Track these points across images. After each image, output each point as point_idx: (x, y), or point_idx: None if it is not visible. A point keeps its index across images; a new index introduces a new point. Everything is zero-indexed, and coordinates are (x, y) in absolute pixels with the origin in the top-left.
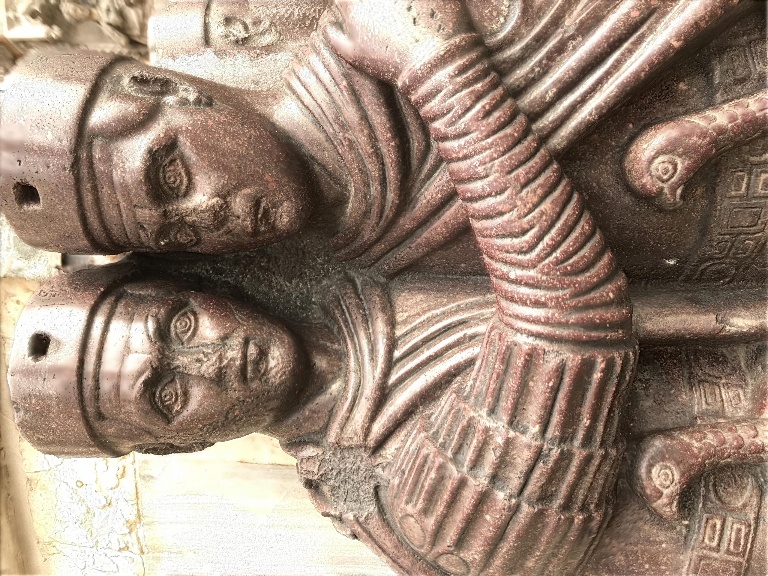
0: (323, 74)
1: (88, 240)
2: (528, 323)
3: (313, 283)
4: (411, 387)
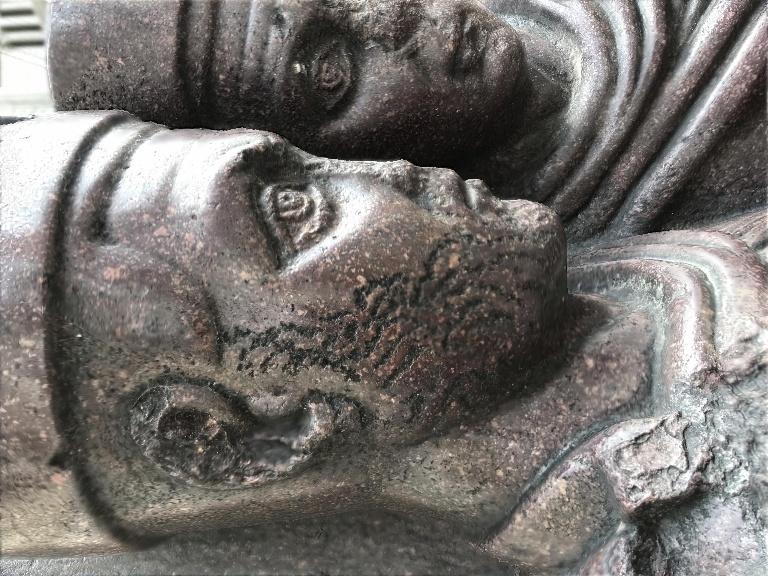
0: None
1: (178, 37)
2: None
3: None
4: None
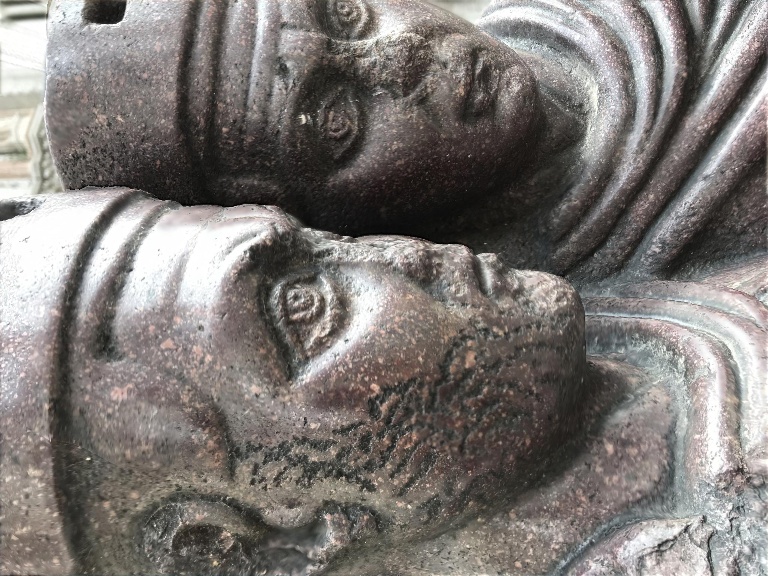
0: None
1: (178, 92)
2: None
3: None
4: None
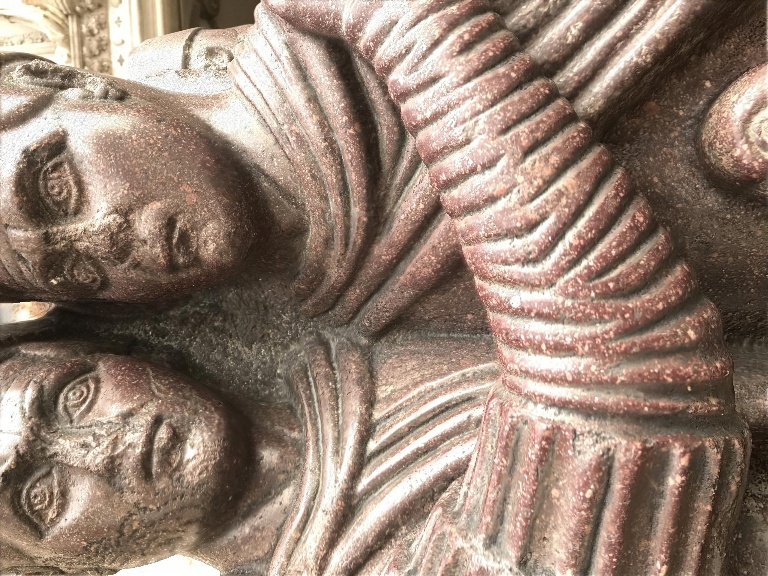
0: (262, 48)
1: None
2: (545, 384)
3: (278, 349)
4: (389, 496)
